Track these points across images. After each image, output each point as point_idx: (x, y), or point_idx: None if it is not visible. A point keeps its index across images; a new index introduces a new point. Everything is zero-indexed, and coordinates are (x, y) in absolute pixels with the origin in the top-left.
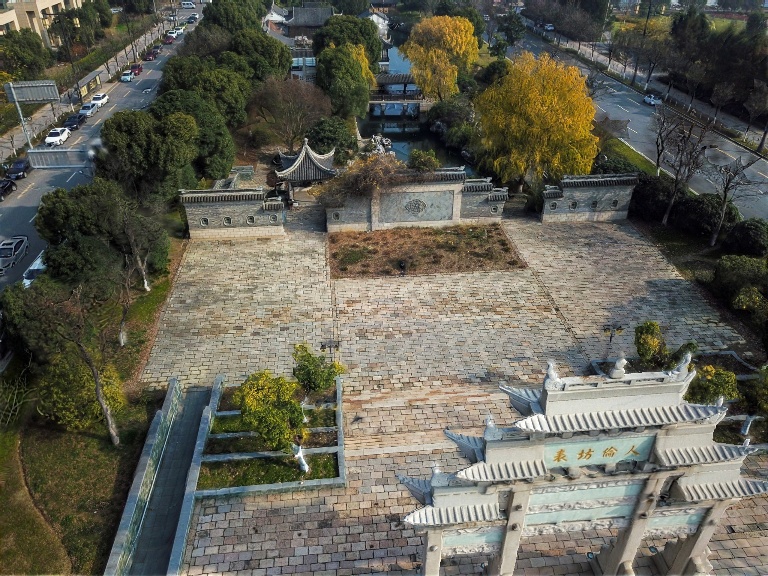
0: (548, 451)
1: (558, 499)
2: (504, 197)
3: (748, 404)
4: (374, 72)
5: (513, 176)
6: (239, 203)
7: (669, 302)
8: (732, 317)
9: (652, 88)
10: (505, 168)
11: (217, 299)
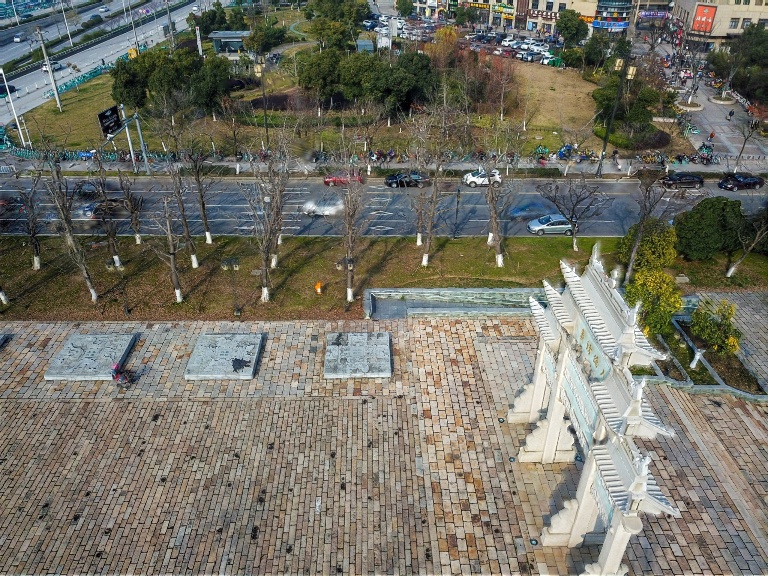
0: None
1: None
2: None
3: None
4: None
5: None
6: None
7: None
8: None
9: None
10: None
11: None
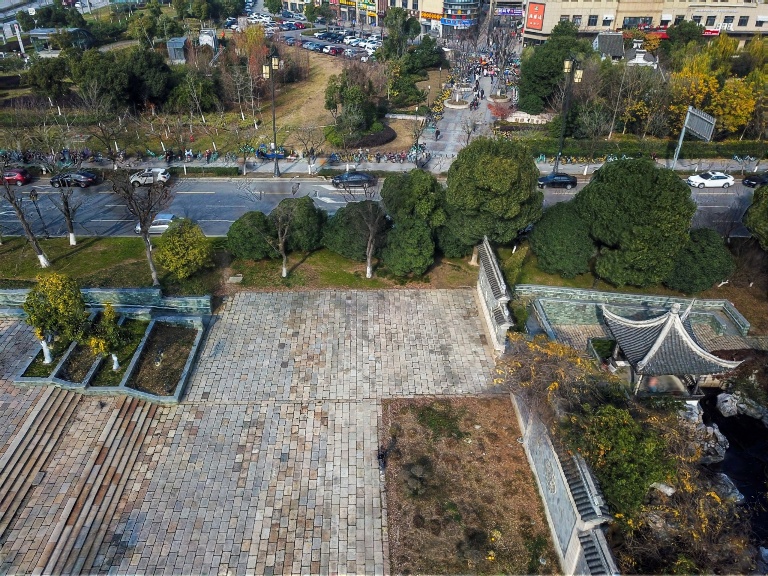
0: None
1: None
2: None
3: None
4: None
5: None
6: None
7: None
8: None
9: None
10: None
11: (349, 317)
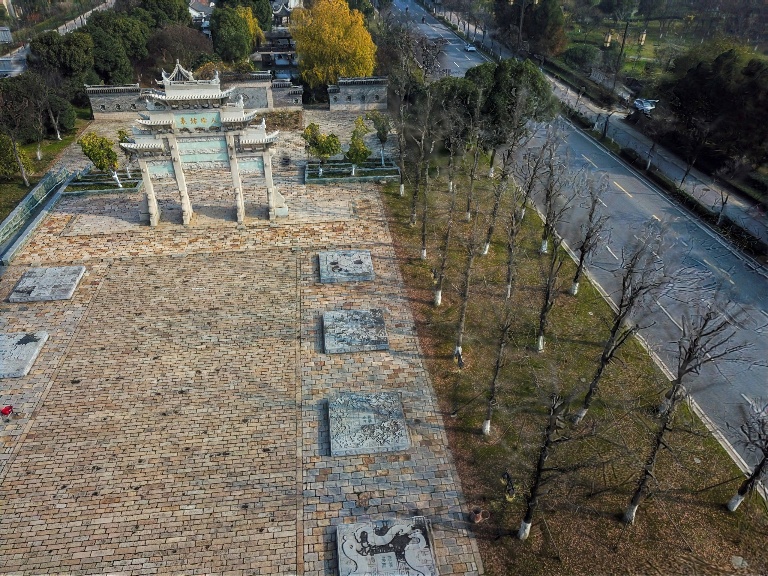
0: (177, 118)
1: (191, 147)
2: (300, 92)
3: (350, 157)
4: (265, 30)
5: (317, 83)
6: (124, 94)
7: (377, 142)
8: (408, 147)
9: (477, 40)
10: (310, 77)
11: None
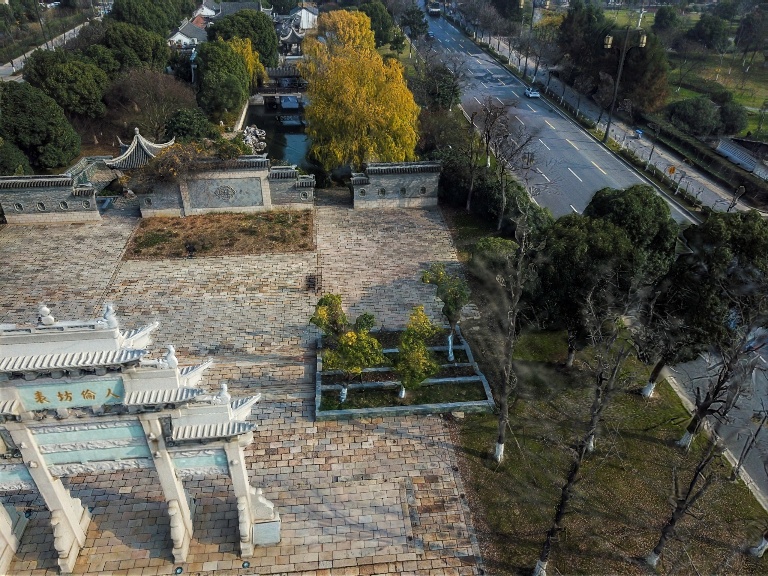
0: (26, 393)
1: (67, 439)
2: (311, 184)
3: None
4: (268, 65)
5: (335, 164)
6: (49, 189)
7: None
8: (481, 295)
9: (538, 81)
10: (326, 156)
11: (2, 279)
